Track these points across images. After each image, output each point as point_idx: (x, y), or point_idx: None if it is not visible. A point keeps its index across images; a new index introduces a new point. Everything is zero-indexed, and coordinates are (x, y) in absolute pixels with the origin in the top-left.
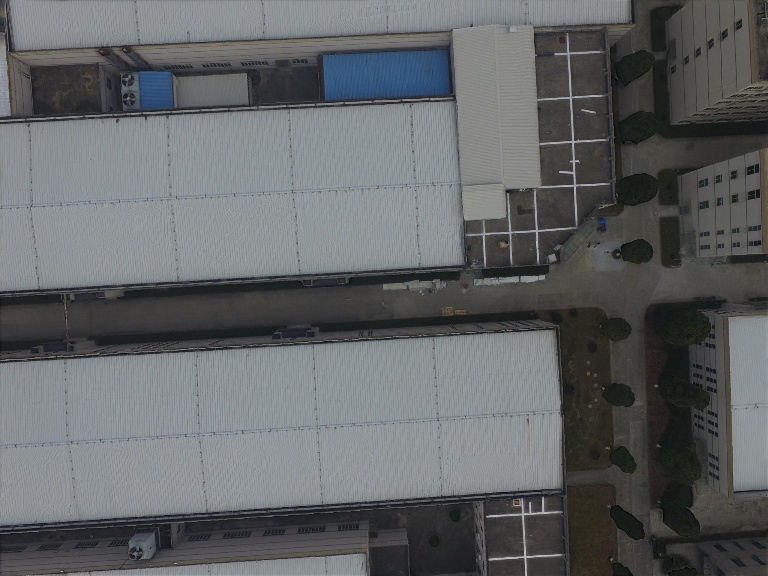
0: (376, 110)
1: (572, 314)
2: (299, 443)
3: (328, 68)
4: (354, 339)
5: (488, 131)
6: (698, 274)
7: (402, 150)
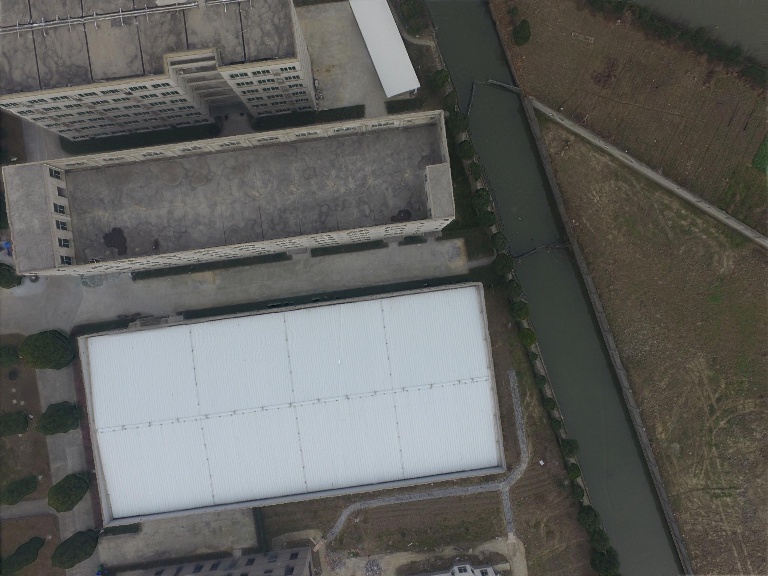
0: None
1: None
2: None
3: None
4: None
5: None
6: (121, 291)
7: None
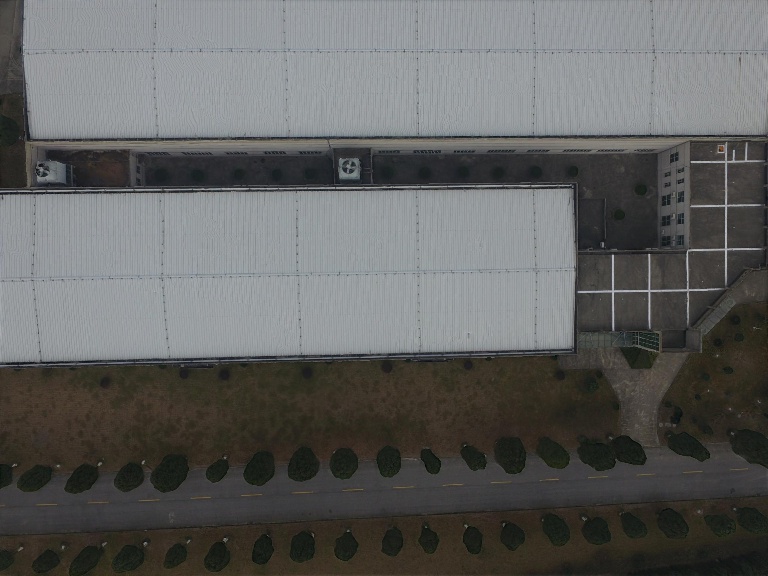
0: None
1: None
2: (516, 67)
3: None
4: None
5: None
6: None
7: None
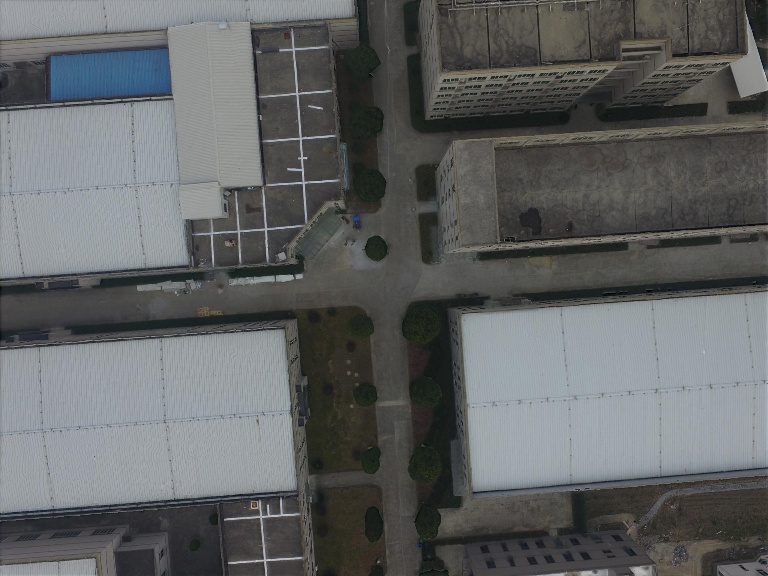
0: (92, 110)
1: (329, 313)
2: (25, 447)
3: (53, 69)
4: (80, 341)
5: (204, 129)
6: (460, 270)
7: (122, 150)
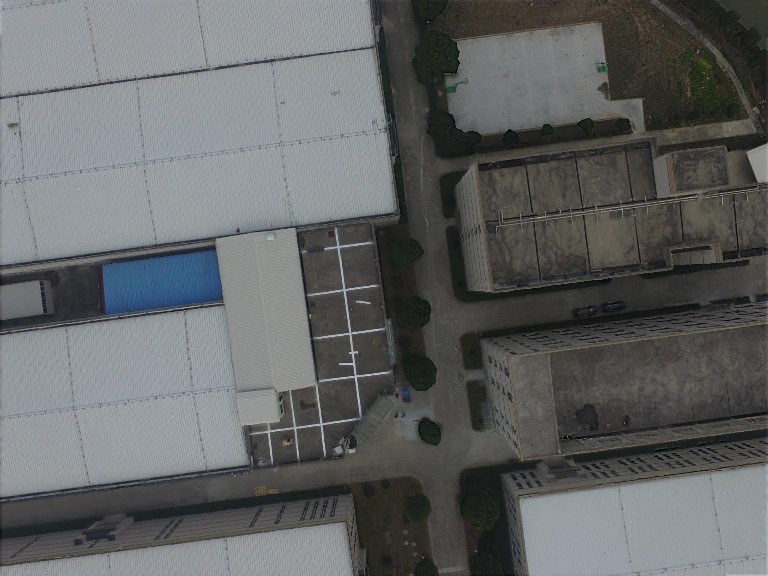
0: (147, 324)
1: (384, 486)
2: None
3: (106, 279)
4: None
5: (257, 337)
6: None
7: (178, 358)
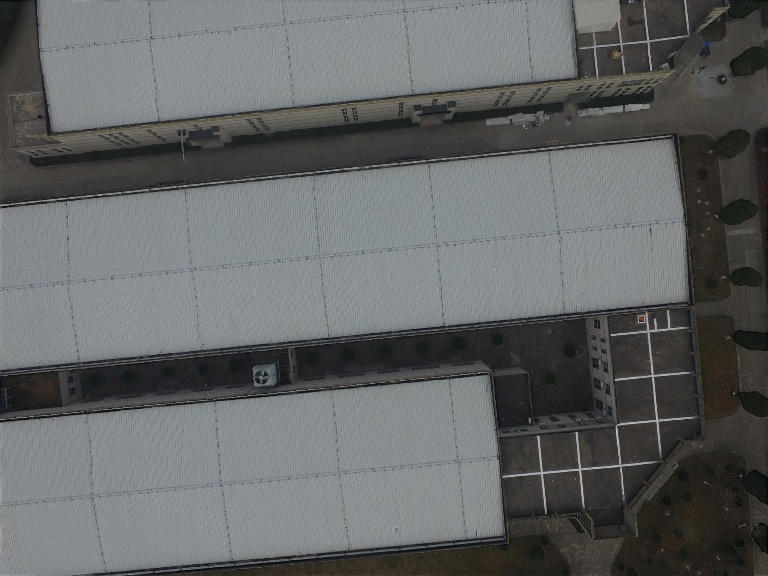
0: None
1: (680, 140)
2: (419, 262)
3: None
4: (470, 156)
5: None
6: None
7: None
